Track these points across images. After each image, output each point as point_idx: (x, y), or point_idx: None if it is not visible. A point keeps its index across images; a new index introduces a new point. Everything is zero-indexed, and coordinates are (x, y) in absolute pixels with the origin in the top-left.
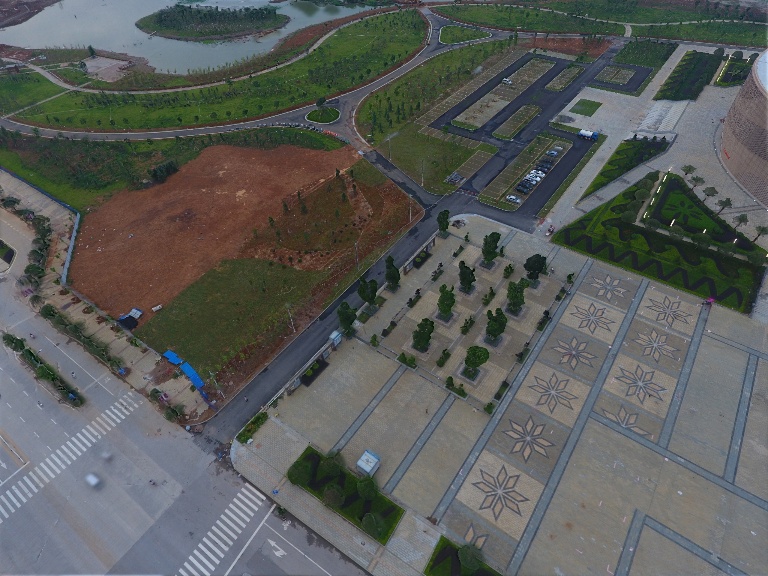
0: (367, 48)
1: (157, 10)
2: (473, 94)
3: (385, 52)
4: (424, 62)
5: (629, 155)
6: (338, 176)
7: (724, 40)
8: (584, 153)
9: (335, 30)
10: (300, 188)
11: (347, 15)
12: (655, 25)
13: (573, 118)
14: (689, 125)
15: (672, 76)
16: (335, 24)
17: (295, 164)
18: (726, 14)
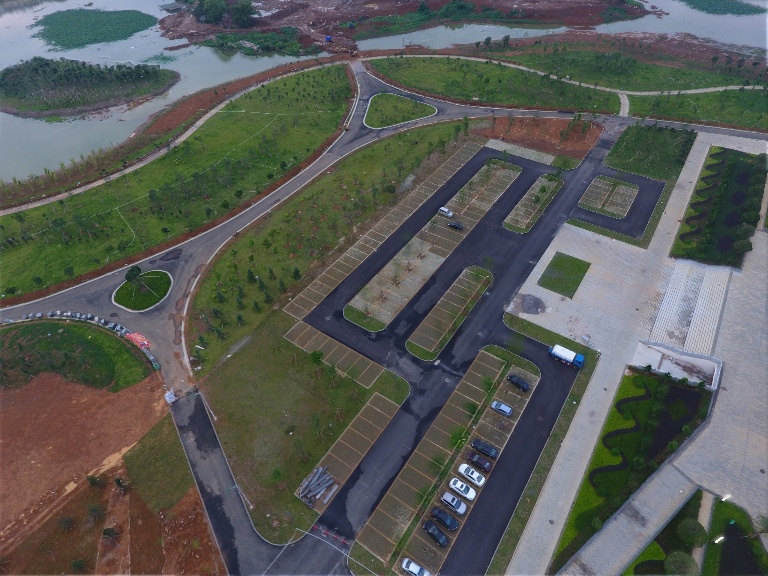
0: (258, 137)
1: (5, 66)
2: (391, 239)
3: (281, 146)
4: (332, 165)
5: (640, 422)
6: (96, 484)
7: (760, 125)
8: (559, 405)
9: (228, 101)
10: (19, 515)
11: (255, 72)
12: (660, 95)
13: (543, 302)
14: (739, 337)
15: (695, 201)
16: (232, 90)
17: (40, 434)
18: (758, 82)
